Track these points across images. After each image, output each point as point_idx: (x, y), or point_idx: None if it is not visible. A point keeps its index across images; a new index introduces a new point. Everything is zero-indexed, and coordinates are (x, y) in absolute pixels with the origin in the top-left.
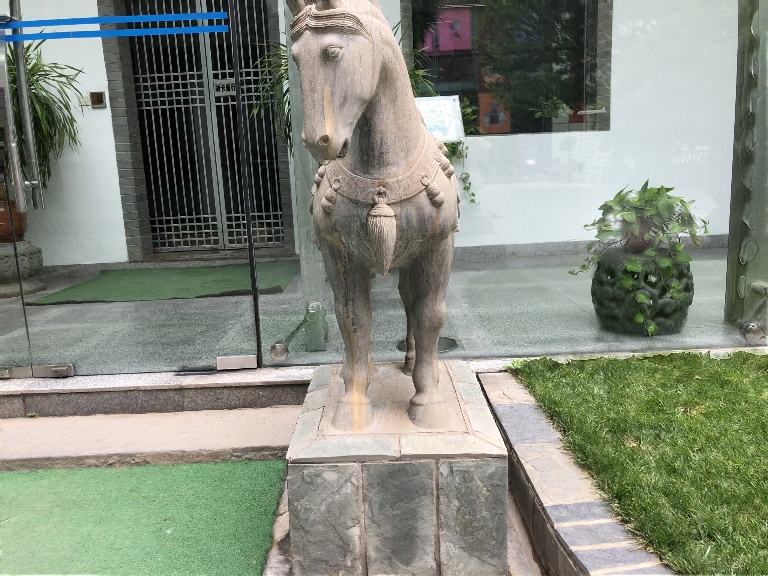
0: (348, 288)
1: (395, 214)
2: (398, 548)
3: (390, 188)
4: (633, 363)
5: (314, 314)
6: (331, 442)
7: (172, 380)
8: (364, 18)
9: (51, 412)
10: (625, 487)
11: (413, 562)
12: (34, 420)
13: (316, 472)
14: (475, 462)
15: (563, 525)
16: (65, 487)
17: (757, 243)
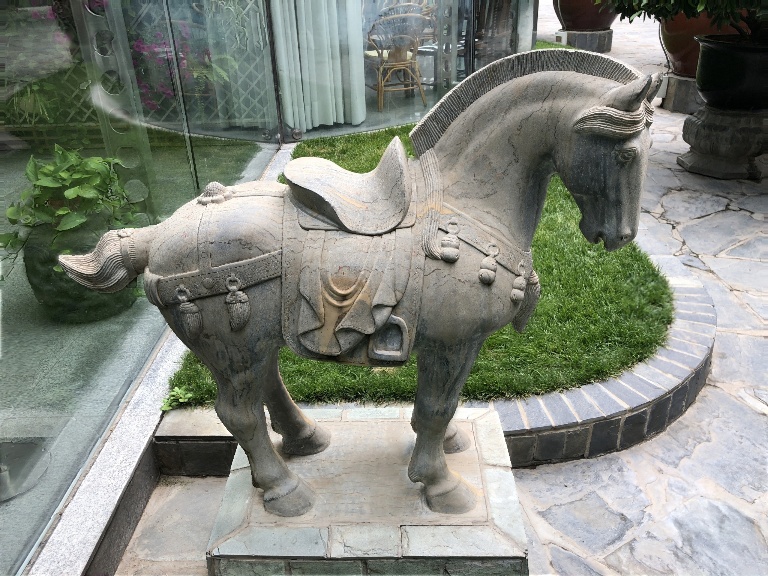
0: None
1: None
2: None
3: None
4: None
5: None
6: (499, 514)
7: None
8: None
9: None
10: (469, 383)
11: None
12: None
13: None
14: None
15: None
16: None
17: (145, 180)
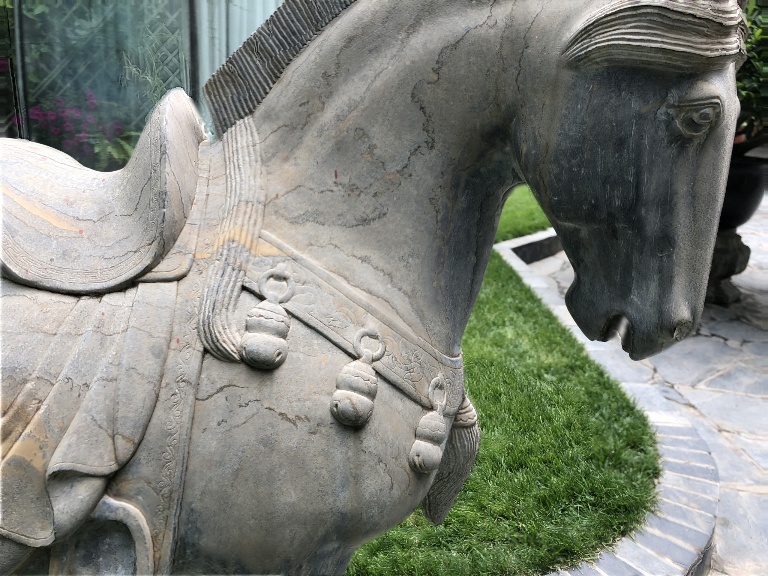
0: None
1: None
2: None
3: None
4: None
5: None
6: None
7: None
8: None
9: None
10: (372, 569)
11: None
12: None
13: None
14: None
15: None
16: None
17: None
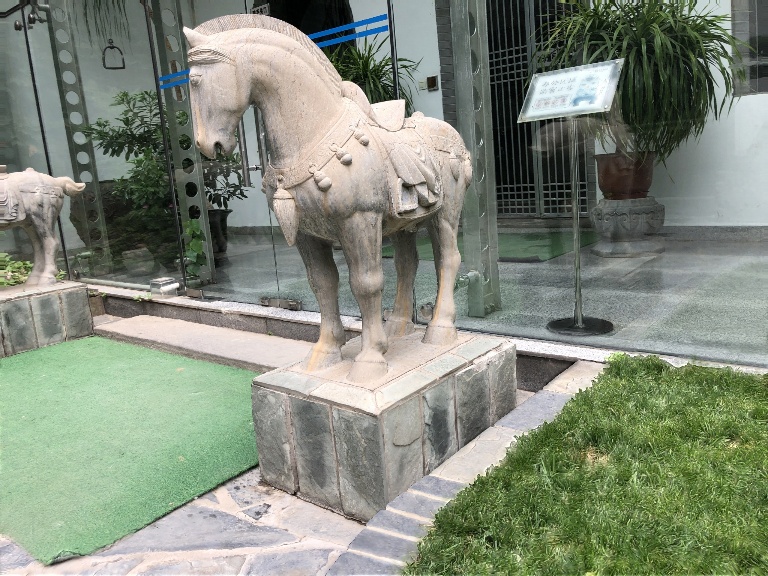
0: (303, 256)
1: (293, 197)
2: (315, 471)
3: (286, 176)
4: (761, 381)
5: (463, 282)
6: (284, 375)
7: (348, 323)
8: (230, 47)
9: (280, 333)
10: (487, 478)
11: (325, 486)
12: (269, 337)
13: (264, 394)
14: (354, 414)
15: (413, 491)
16: (239, 382)
17: None
